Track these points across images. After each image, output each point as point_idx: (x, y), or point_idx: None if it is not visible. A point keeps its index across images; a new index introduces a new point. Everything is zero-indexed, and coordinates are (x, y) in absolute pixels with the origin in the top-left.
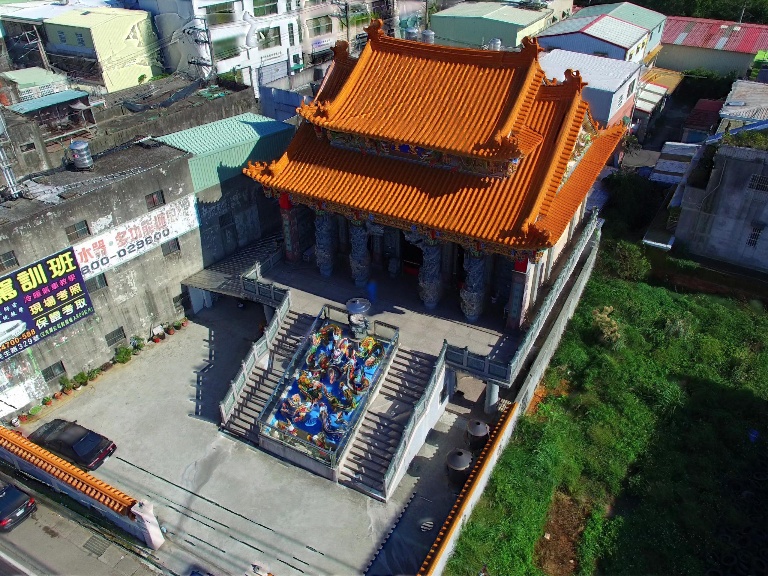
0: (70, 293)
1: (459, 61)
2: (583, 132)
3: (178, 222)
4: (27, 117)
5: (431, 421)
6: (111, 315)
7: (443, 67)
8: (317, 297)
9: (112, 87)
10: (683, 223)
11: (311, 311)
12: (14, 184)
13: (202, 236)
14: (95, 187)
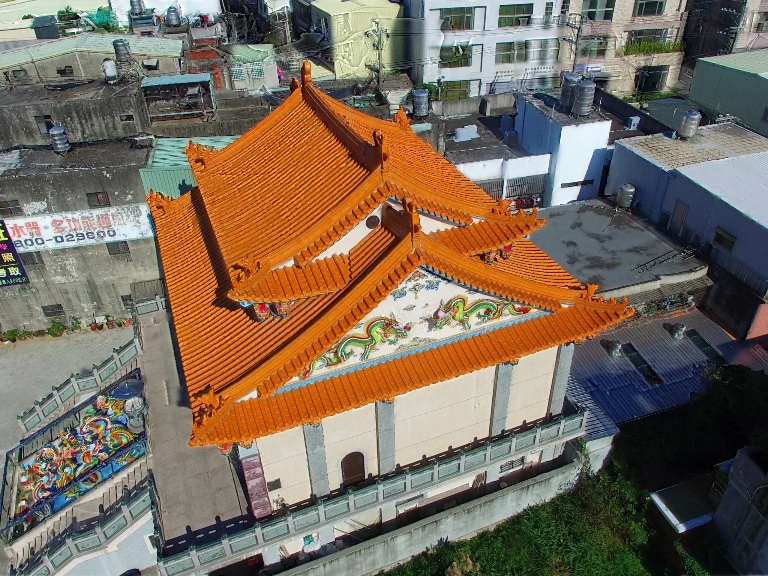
0: (3, 259)
1: (343, 139)
2: (476, 295)
3: (127, 227)
4: (138, 91)
5: (132, 561)
6: (49, 290)
7: (328, 142)
8: (172, 357)
9: (342, 74)
10: (726, 504)
11: (147, 369)
12: None
13: (158, 247)
14: (36, 172)
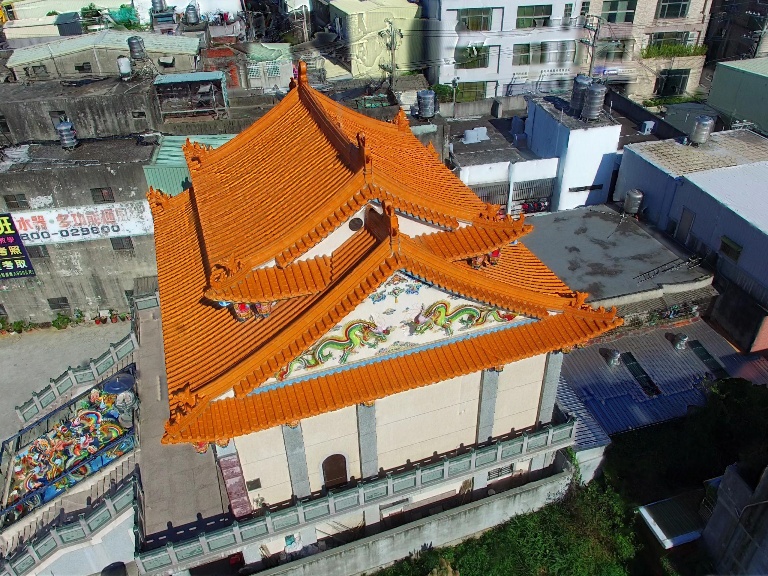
0: (10, 252)
1: (332, 140)
2: (459, 300)
3: (131, 222)
4: (151, 88)
5: (117, 554)
6: (54, 283)
7: (319, 143)
8: None
9: None
10: (715, 522)
11: (142, 364)
12: None
13: None
14: (42, 167)
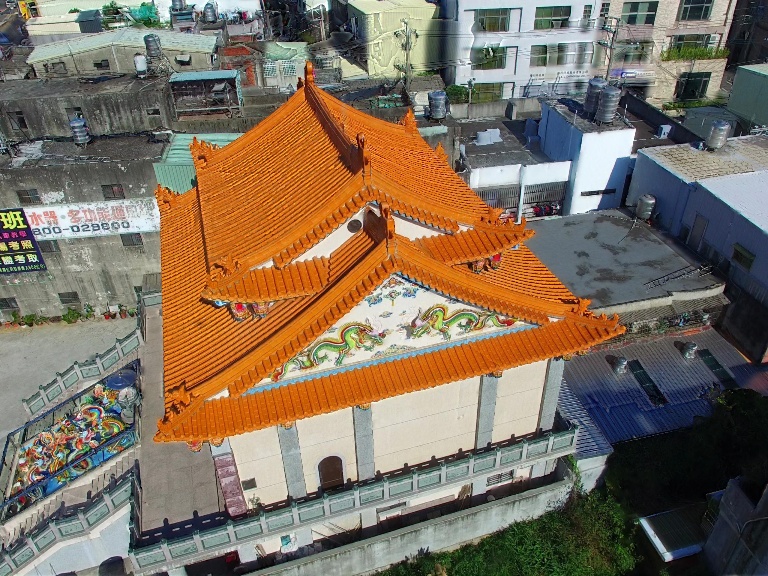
0: (22, 246)
1: (335, 141)
2: (457, 305)
3: (141, 219)
4: (166, 86)
5: (115, 548)
6: (65, 278)
7: (322, 143)
8: None
9: None
10: (716, 536)
11: (147, 360)
12: (2, 141)
13: None
14: (54, 163)
